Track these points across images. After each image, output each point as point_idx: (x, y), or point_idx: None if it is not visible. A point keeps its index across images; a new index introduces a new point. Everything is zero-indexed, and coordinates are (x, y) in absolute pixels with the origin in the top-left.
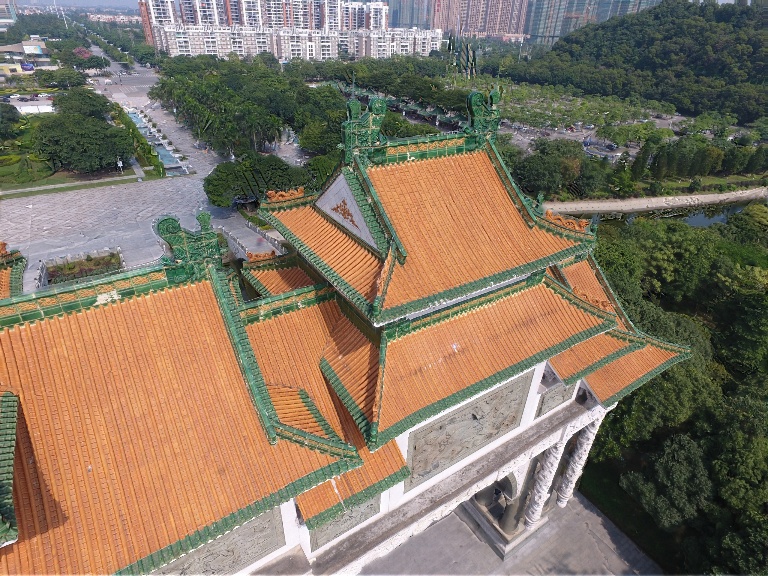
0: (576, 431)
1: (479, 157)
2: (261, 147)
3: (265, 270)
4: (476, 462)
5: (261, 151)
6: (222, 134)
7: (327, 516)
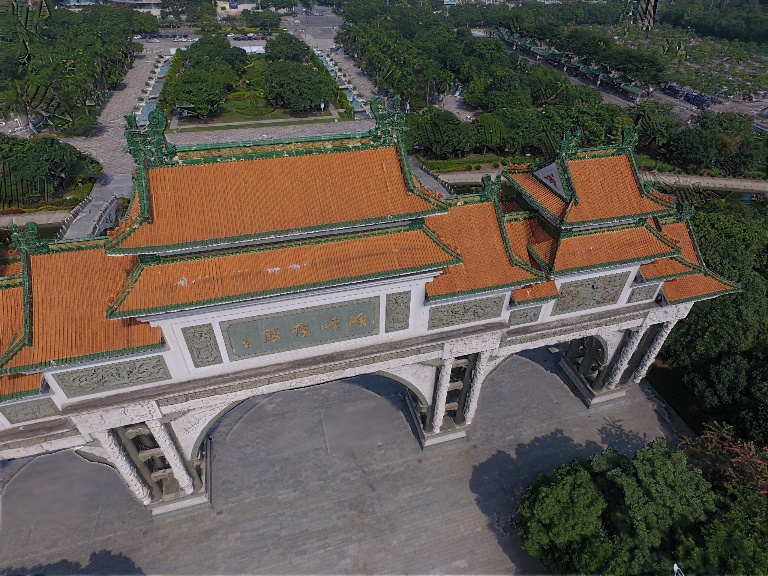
0: (653, 324)
1: (623, 158)
2: (429, 97)
3: None
4: (588, 315)
5: (431, 102)
6: (403, 86)
7: (525, 302)
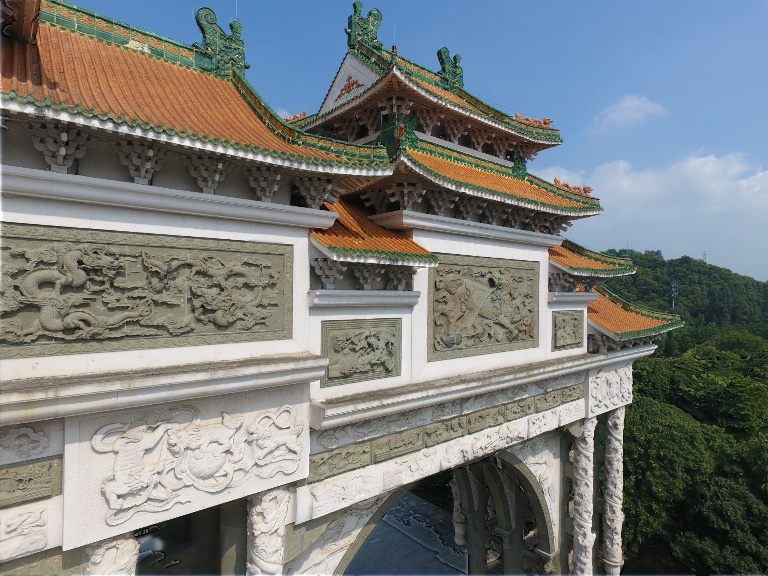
0: (600, 412)
1: None
2: None
3: None
4: (501, 369)
5: None
6: None
7: (353, 252)
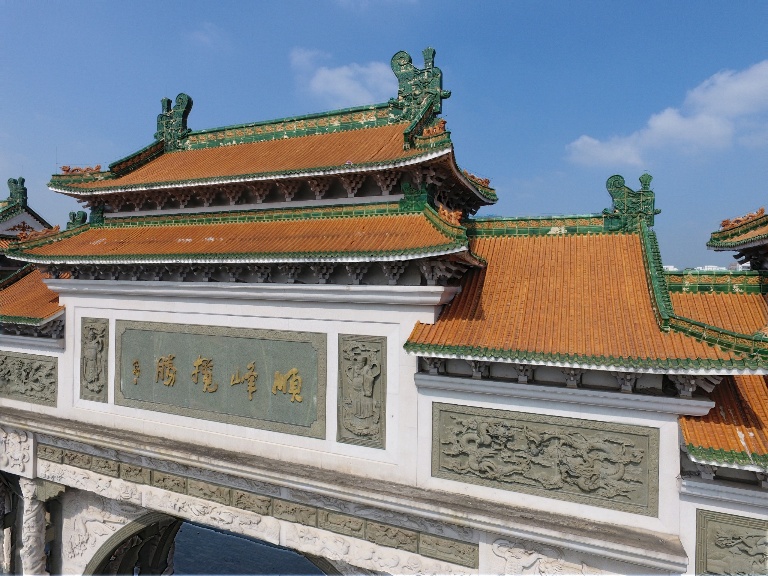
0: None
1: None
2: None
3: None
4: None
5: None
6: None
7: (721, 455)
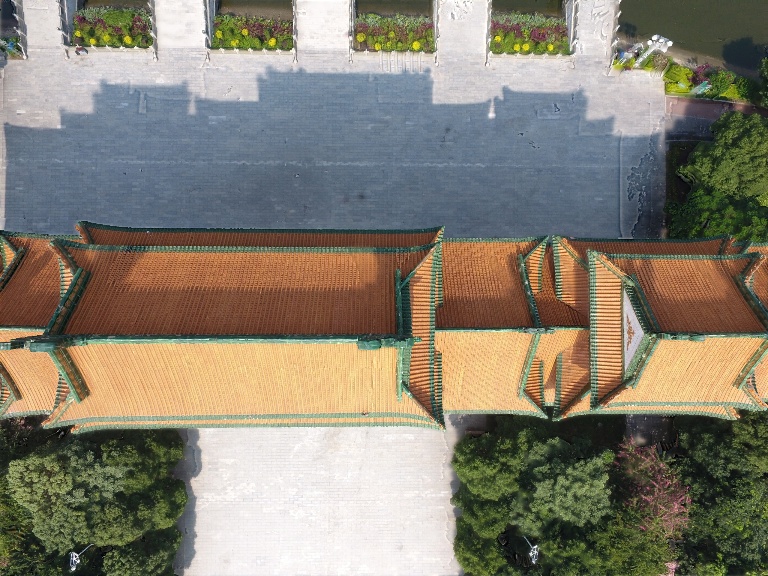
0: None
1: (756, 339)
2: None
3: (568, 252)
4: None
5: None
6: None
7: None
